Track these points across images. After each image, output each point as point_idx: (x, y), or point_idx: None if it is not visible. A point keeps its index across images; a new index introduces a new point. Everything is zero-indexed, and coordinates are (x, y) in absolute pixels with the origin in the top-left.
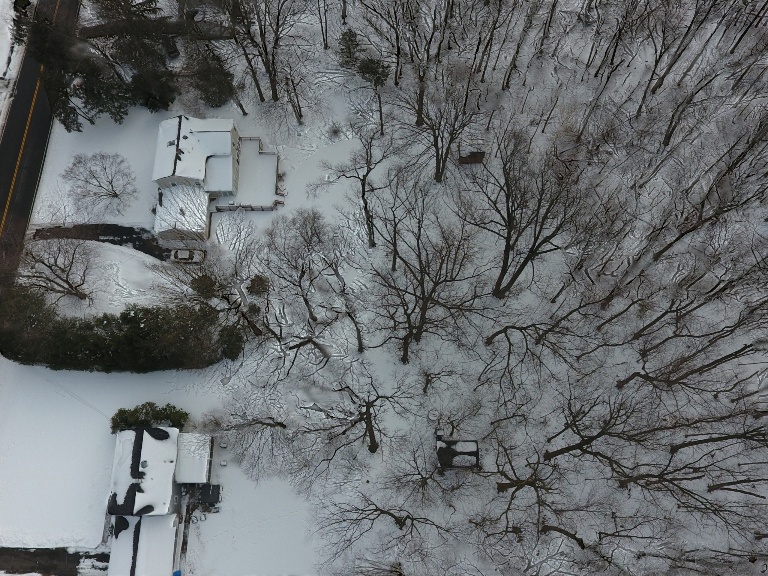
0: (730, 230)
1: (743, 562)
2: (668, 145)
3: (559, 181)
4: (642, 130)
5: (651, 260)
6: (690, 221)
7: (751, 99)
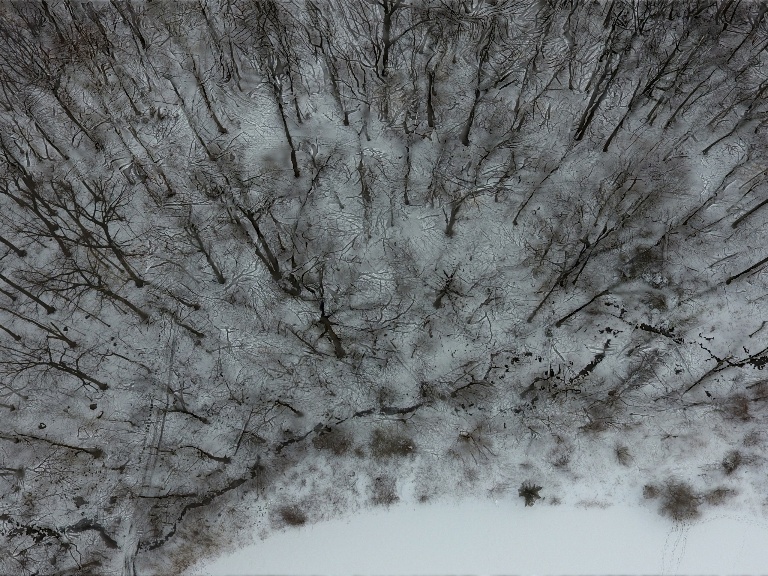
0: (180, 125)
1: (82, 408)
2: (145, 48)
3: (31, 76)
4: (129, 34)
5: (94, 148)
6: (142, 115)
7: (222, 7)
